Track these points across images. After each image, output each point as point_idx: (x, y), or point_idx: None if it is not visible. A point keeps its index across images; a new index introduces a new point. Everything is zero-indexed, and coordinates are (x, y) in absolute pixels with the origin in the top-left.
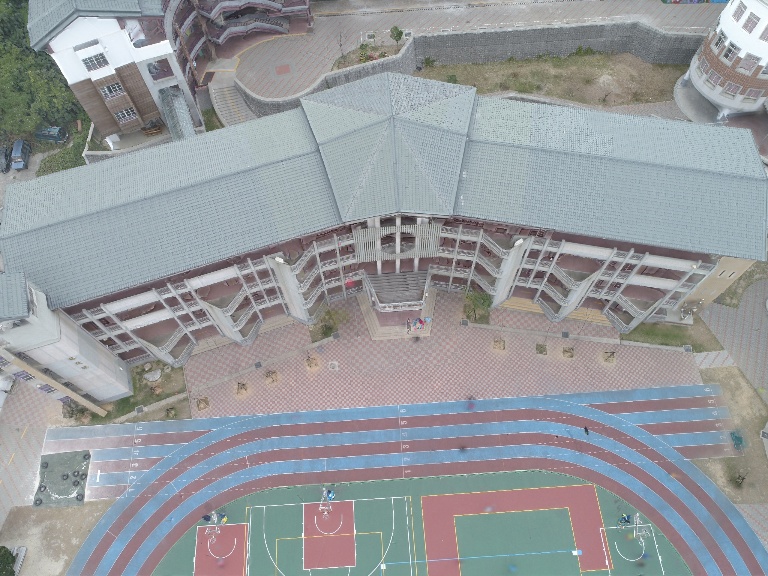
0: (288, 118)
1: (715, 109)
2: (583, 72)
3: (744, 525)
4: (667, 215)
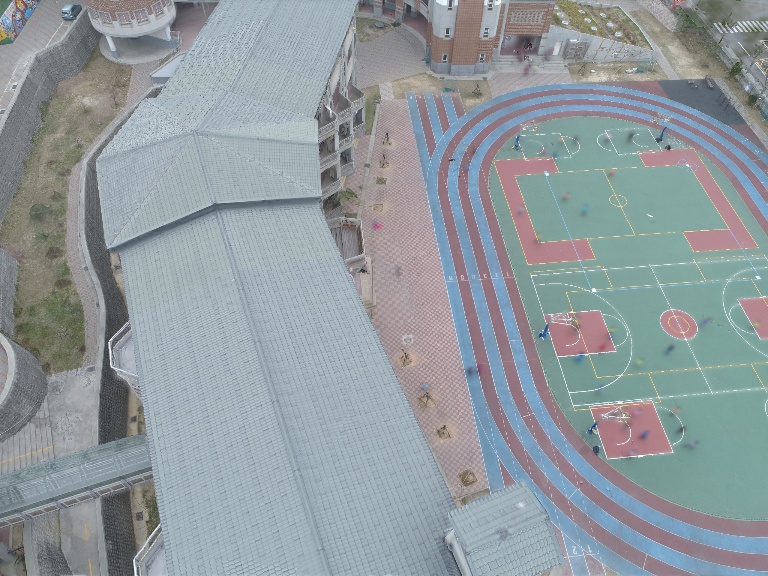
0: (139, 262)
1: (154, 44)
2: (71, 114)
3: (505, 96)
4: (326, 8)
